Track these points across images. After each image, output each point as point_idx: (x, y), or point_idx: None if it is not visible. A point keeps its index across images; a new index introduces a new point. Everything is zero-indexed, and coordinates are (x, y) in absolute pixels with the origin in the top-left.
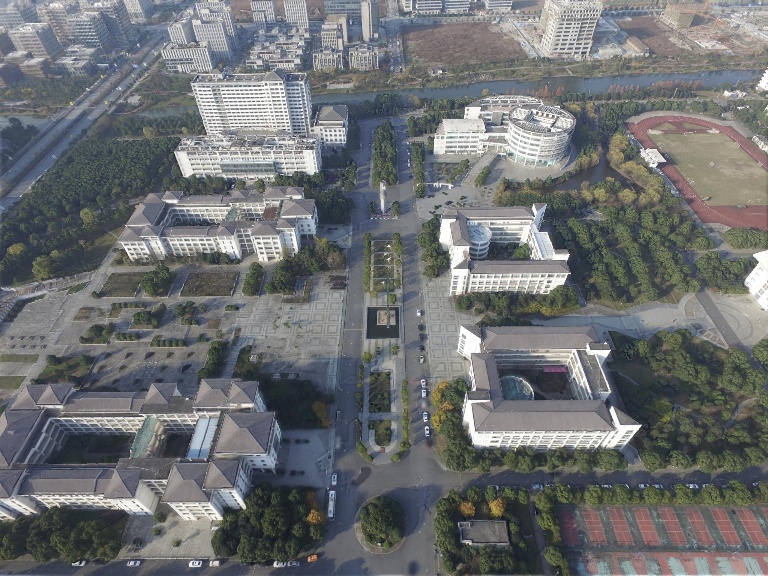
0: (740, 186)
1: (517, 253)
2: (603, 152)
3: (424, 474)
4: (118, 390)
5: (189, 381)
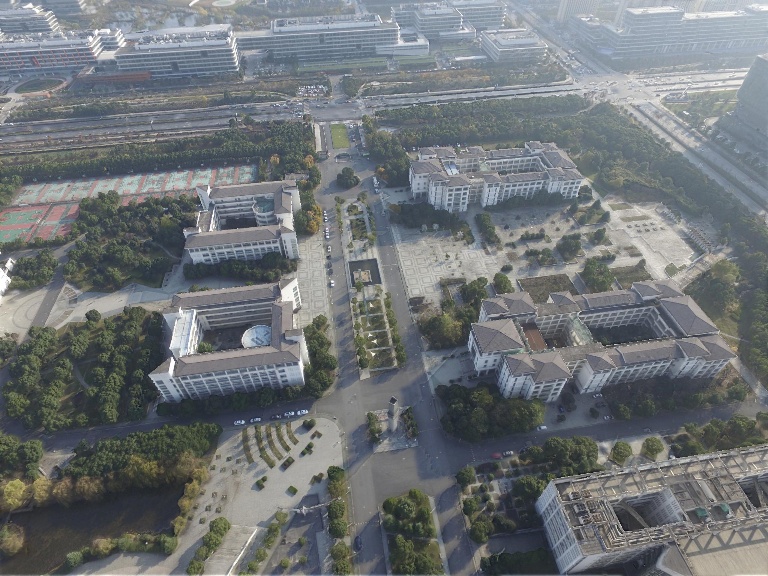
0: None
1: None
2: None
3: (327, 198)
4: (535, 202)
5: (497, 221)
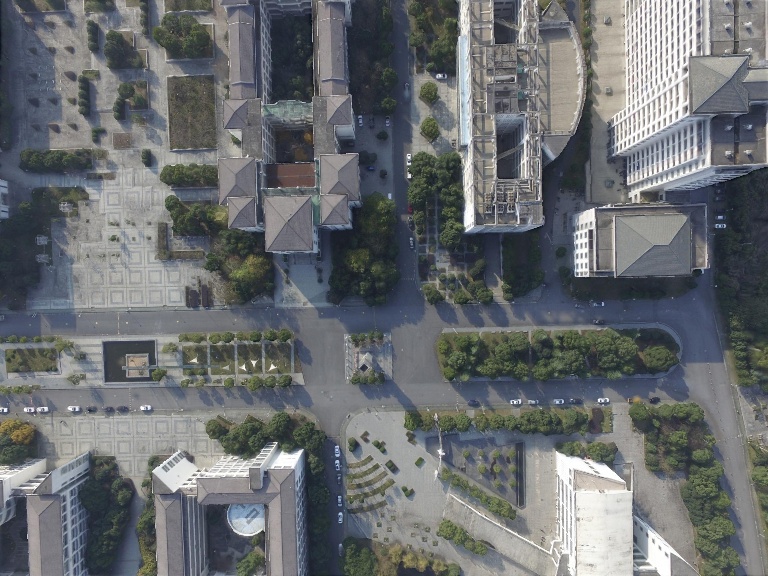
0: None
1: (251, 558)
2: None
3: None
4: (1, 63)
5: (37, 138)
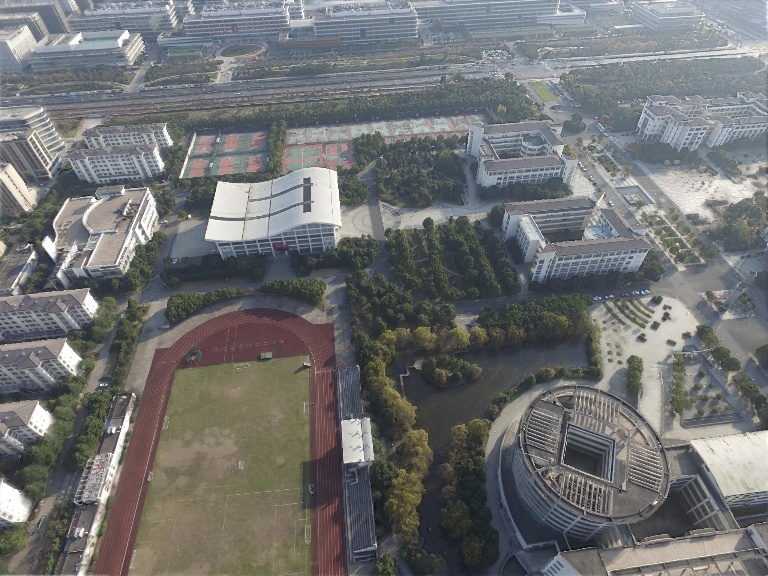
0: (234, 404)
1: None
2: (440, 466)
3: None
4: (760, 142)
5: None
